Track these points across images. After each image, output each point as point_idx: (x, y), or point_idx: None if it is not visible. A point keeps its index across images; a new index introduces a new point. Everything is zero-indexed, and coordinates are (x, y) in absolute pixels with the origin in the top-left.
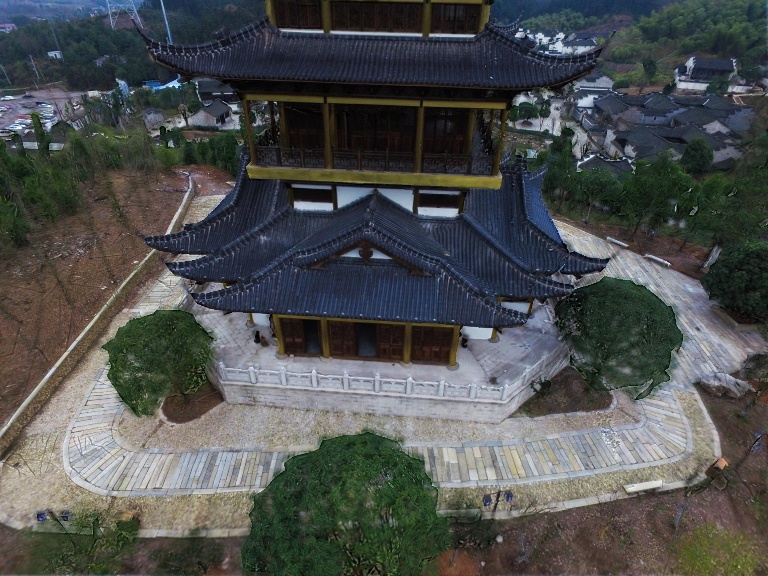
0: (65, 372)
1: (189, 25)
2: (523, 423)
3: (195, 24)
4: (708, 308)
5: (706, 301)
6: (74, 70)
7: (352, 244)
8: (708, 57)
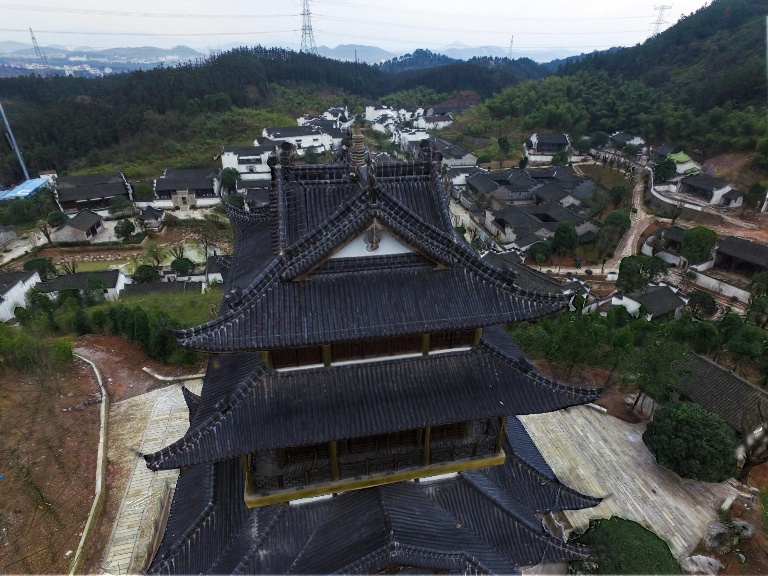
0: None
1: (34, 119)
2: None
3: (41, 118)
4: (652, 460)
5: (647, 450)
6: None
7: (379, 570)
8: (546, 133)
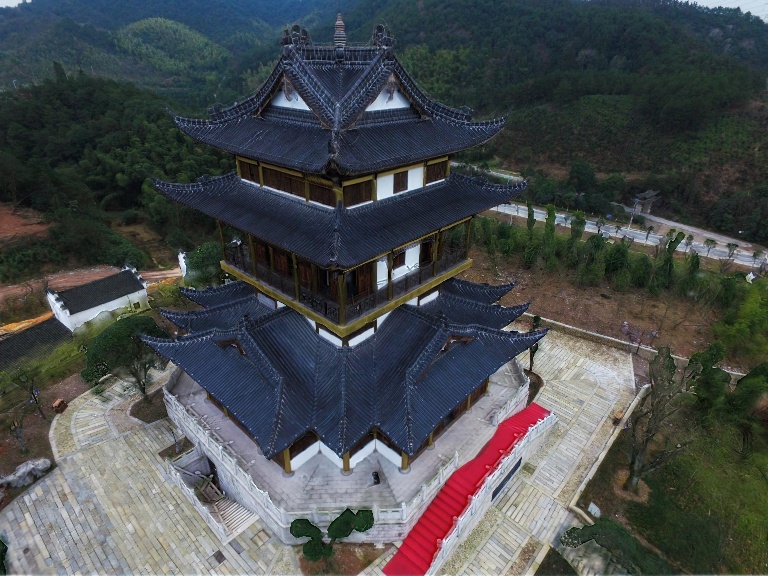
0: None
1: None
2: None
3: None
4: None
5: None
6: None
7: None
8: None
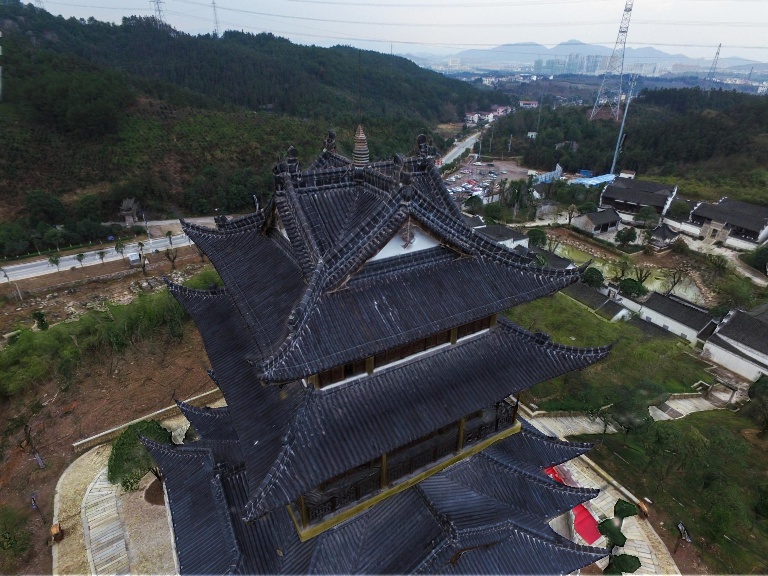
0: (171, 414)
1: (654, 125)
2: None
3: (661, 125)
4: None
5: None
6: (533, 151)
7: None
8: None
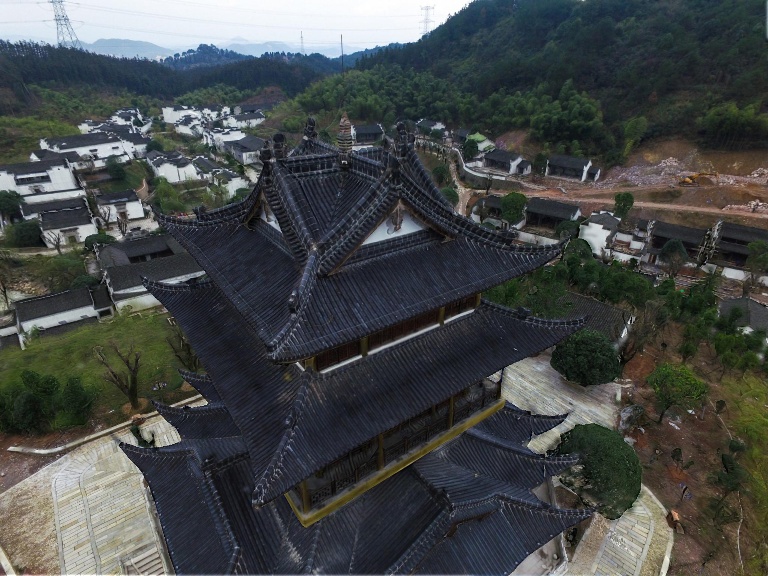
0: None
1: None
2: (572, 572)
3: None
4: (559, 381)
5: (553, 375)
6: None
7: (444, 534)
8: (361, 124)
